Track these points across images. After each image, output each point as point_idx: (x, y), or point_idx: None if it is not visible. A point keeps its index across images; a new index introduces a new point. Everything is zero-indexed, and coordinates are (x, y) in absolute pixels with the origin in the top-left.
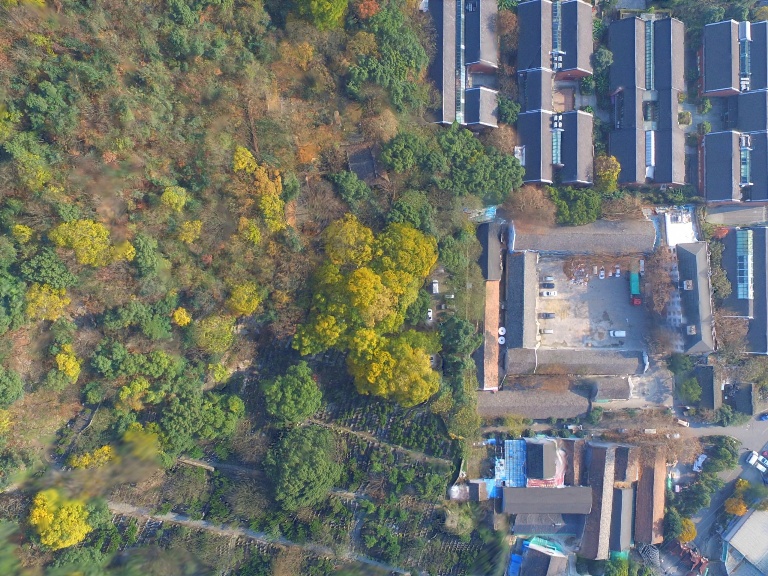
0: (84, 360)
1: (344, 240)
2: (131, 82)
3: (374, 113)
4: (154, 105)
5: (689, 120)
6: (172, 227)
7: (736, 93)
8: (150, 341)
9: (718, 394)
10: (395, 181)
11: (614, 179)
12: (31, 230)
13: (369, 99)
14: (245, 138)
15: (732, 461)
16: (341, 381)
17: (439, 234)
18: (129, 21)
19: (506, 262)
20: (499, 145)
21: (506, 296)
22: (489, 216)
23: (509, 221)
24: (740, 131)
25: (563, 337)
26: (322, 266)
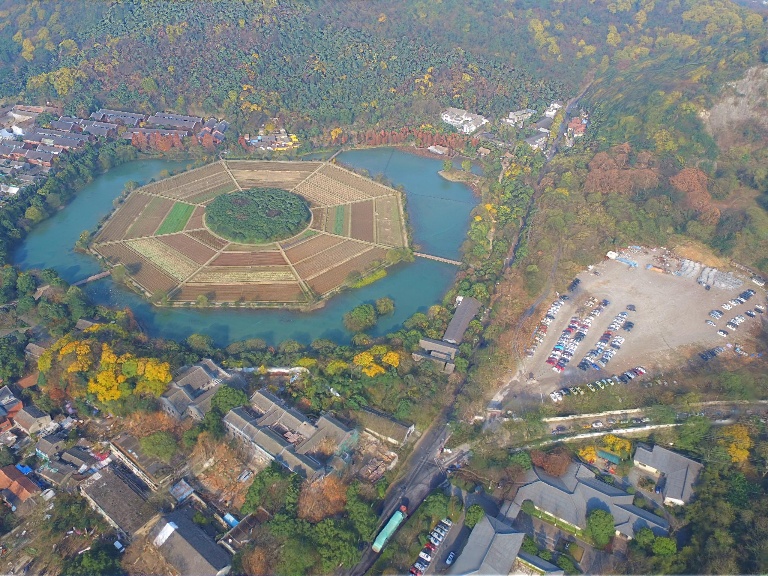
0: None
1: None
2: None
3: None
4: None
5: None
6: None
7: None
8: None
9: None
10: None
11: None
12: None
13: None
14: None
15: None
16: None
17: None
18: None
19: None
20: None
21: None
22: None
23: None
24: None
25: None
26: None
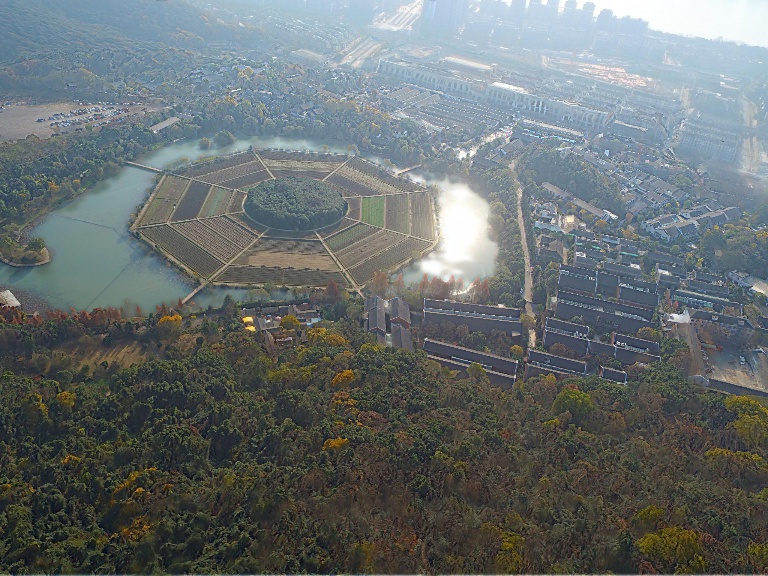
0: None
1: None
2: None
3: None
4: None
5: None
6: None
7: None
8: None
9: None
10: None
11: None
12: None
13: None
14: None
15: None
16: None
17: None
18: None
19: None
20: None
21: None
22: None
23: None
24: None
25: (752, 384)
26: None
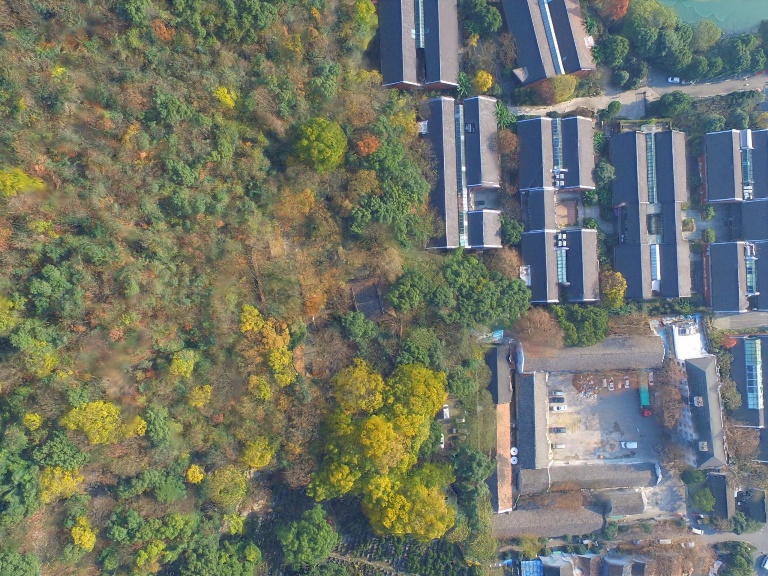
0: (100, 531)
1: (355, 392)
2: (134, 247)
3: (378, 244)
4: (158, 271)
5: (693, 227)
6: (182, 394)
7: (739, 201)
8: (165, 506)
9: (731, 502)
10: (402, 315)
11: (621, 296)
12: (41, 419)
13: (372, 234)
14: (250, 285)
15: (748, 569)
16: (356, 516)
17: (448, 364)
18: (129, 187)
19: (515, 382)
20: (504, 269)
21: (517, 416)
22: (497, 337)
23: (517, 341)
24: (745, 240)
25: (575, 450)
26: (333, 415)
